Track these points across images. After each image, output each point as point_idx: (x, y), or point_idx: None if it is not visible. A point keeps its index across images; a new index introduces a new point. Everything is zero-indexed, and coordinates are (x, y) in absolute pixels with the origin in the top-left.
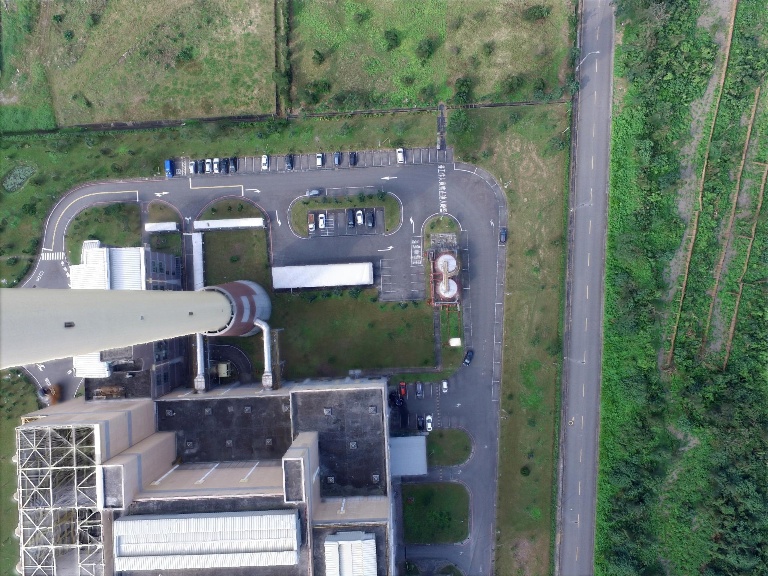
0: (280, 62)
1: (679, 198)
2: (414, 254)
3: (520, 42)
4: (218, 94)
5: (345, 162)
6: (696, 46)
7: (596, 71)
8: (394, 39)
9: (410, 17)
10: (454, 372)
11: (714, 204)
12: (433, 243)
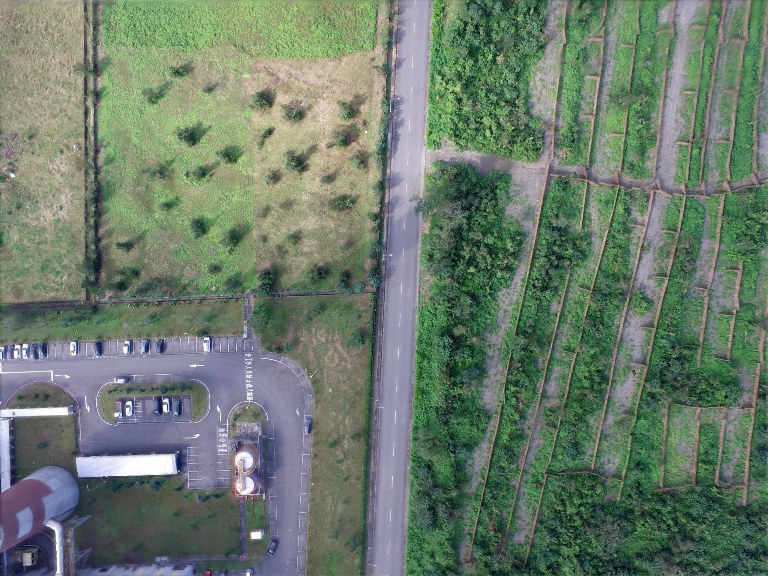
0: (91, 247)
1: (484, 389)
2: (220, 442)
3: (327, 231)
4: (28, 280)
5: (153, 349)
6: (501, 237)
7: (403, 261)
8: (198, 230)
9: (218, 204)
10: (259, 561)
11: (518, 396)
12: (238, 432)
